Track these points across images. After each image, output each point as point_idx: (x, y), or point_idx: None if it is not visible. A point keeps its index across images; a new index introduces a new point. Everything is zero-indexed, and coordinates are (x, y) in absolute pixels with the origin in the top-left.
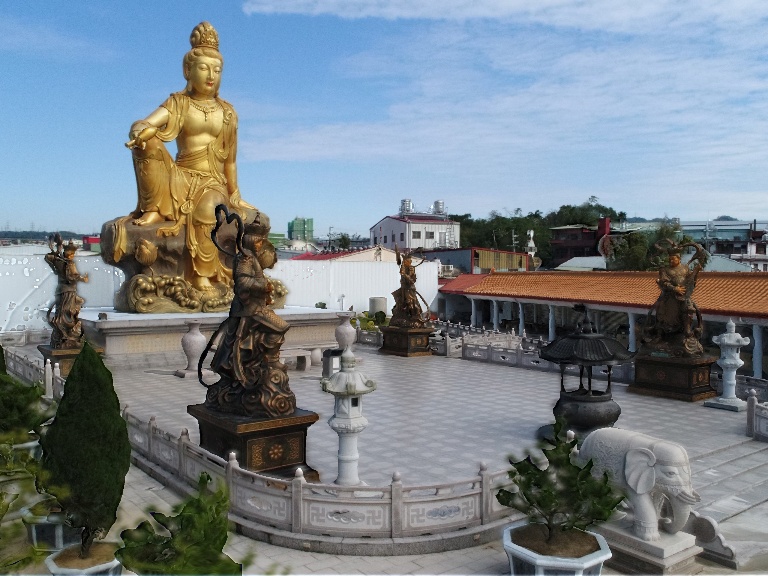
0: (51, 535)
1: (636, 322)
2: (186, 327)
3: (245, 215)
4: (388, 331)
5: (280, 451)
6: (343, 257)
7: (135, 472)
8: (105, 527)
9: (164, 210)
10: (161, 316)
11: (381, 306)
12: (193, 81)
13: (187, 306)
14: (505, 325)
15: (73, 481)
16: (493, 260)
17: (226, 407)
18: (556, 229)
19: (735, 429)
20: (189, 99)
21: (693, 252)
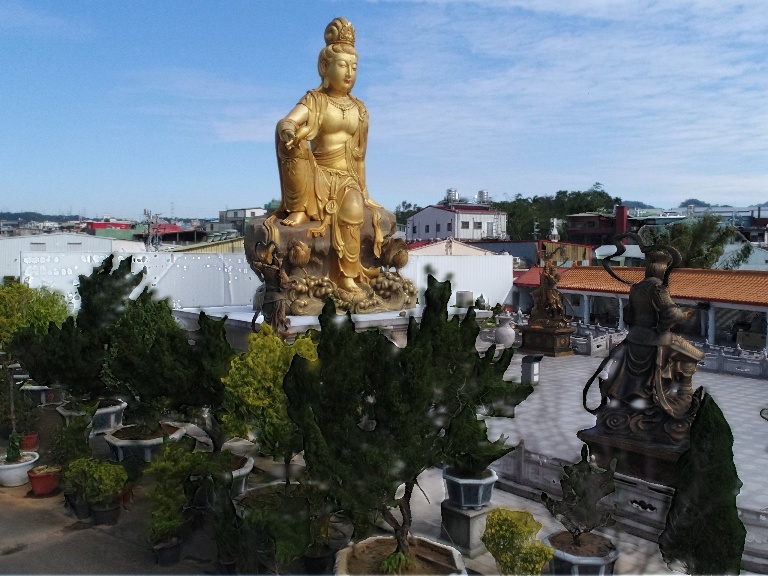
0: (595, 575)
1: (759, 320)
2: None
3: (379, 214)
4: (530, 331)
5: None
6: (415, 250)
7: (509, 496)
8: (734, 575)
9: (310, 210)
10: None
11: (469, 300)
12: (330, 78)
13: (340, 308)
14: (591, 319)
15: (723, 532)
16: (559, 252)
17: (642, 435)
18: (573, 216)
19: None
20: (326, 96)
21: (736, 243)
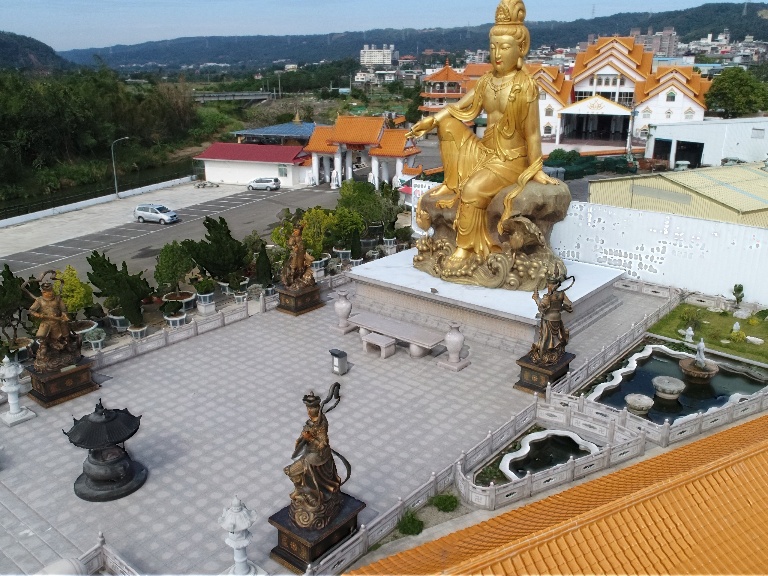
0: None
1: None
2: (394, 290)
3: (516, 193)
4: None
5: None
6: None
7: None
8: None
9: (451, 184)
10: (396, 275)
11: None
12: None
13: None
14: None
15: None
16: None
17: None
18: None
19: (134, 561)
20: (491, 77)
21: None
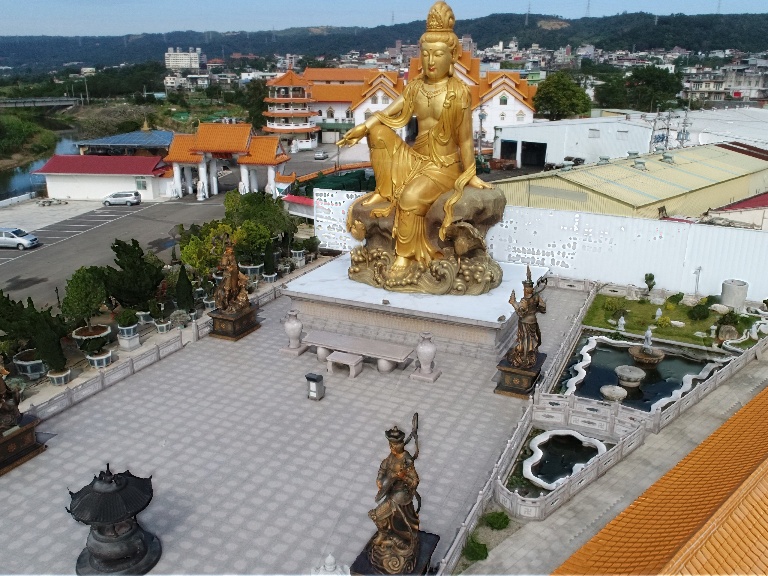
0: None
1: None
2: (339, 304)
3: (455, 199)
4: None
5: None
6: None
7: None
8: None
9: (385, 192)
10: (337, 289)
11: (730, 295)
12: None
13: (376, 280)
14: None
15: None
16: None
17: None
18: None
19: None
20: (421, 84)
21: None
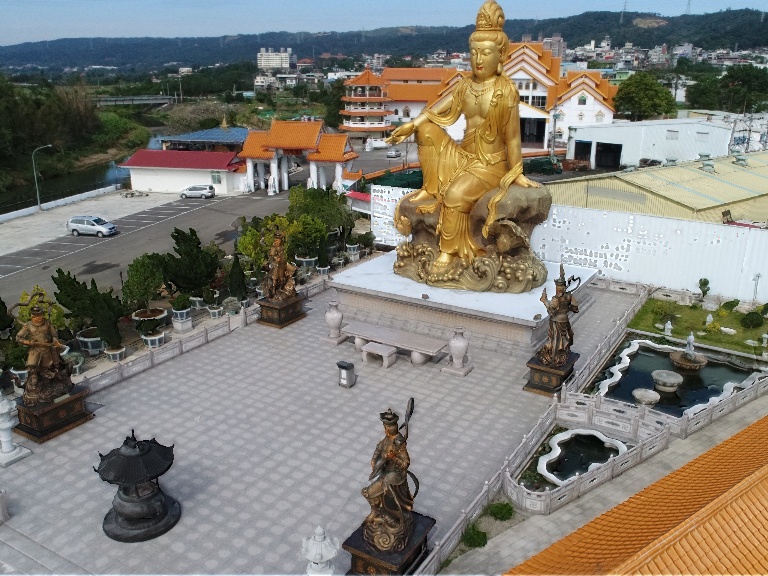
0: None
1: None
2: (381, 297)
3: (500, 197)
4: None
5: None
6: None
7: None
8: None
9: (431, 189)
10: (380, 282)
11: None
12: None
13: (419, 275)
14: None
15: None
16: None
17: None
18: None
19: None
20: (470, 83)
21: None
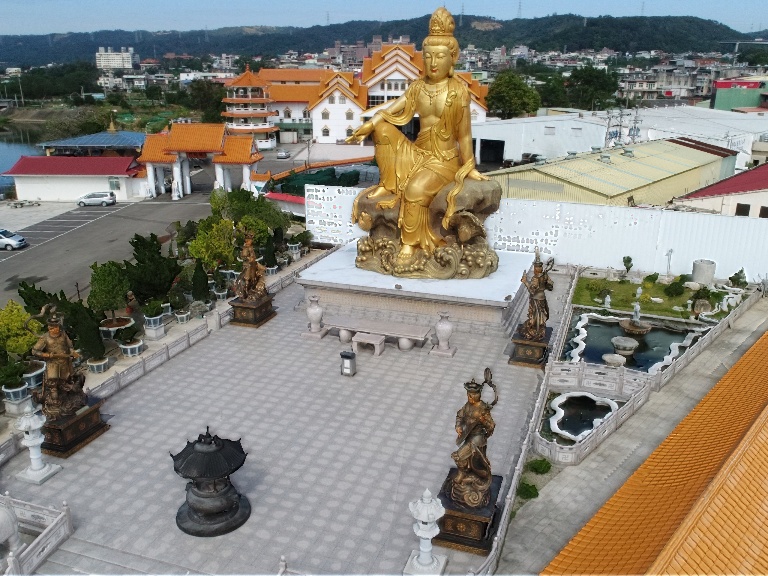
0: None
1: None
2: None
3: (457, 190)
4: None
5: (50, 436)
6: (735, 194)
7: None
8: None
9: (389, 185)
10: (348, 277)
11: (701, 273)
12: None
13: (384, 268)
14: None
15: None
16: None
17: None
18: None
19: None
20: (423, 84)
21: None
